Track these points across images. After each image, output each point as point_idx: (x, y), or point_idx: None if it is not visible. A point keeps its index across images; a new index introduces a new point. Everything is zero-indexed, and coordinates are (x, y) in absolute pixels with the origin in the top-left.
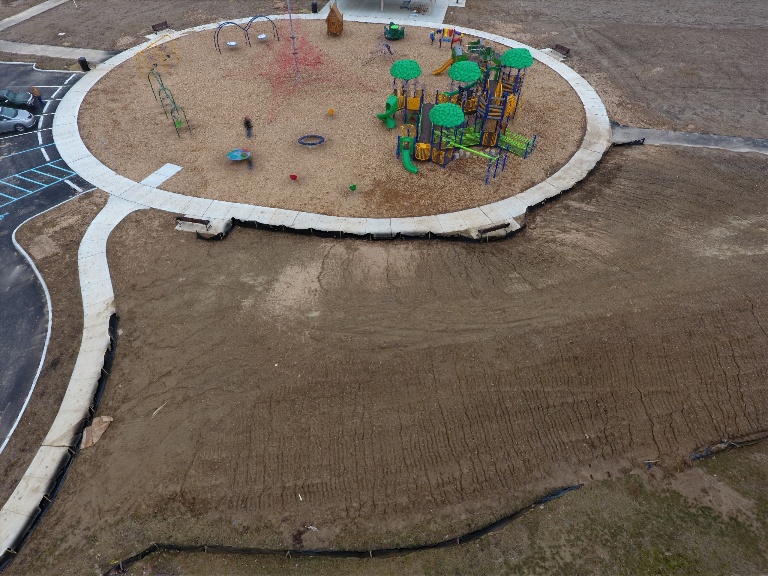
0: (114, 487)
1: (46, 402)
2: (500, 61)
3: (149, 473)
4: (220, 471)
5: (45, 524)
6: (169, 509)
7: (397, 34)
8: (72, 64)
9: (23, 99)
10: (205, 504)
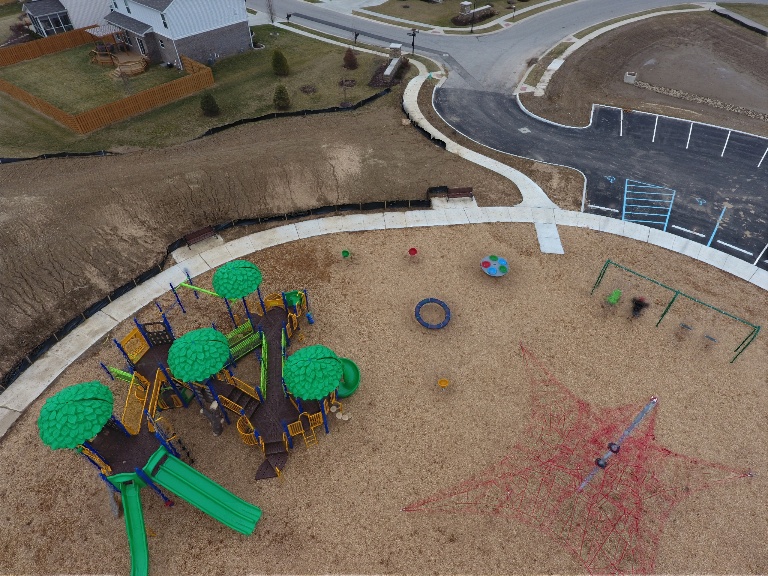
0: None
1: (440, 125)
2: None
3: None
4: None
5: None
6: None
7: None
8: None
9: None
10: None
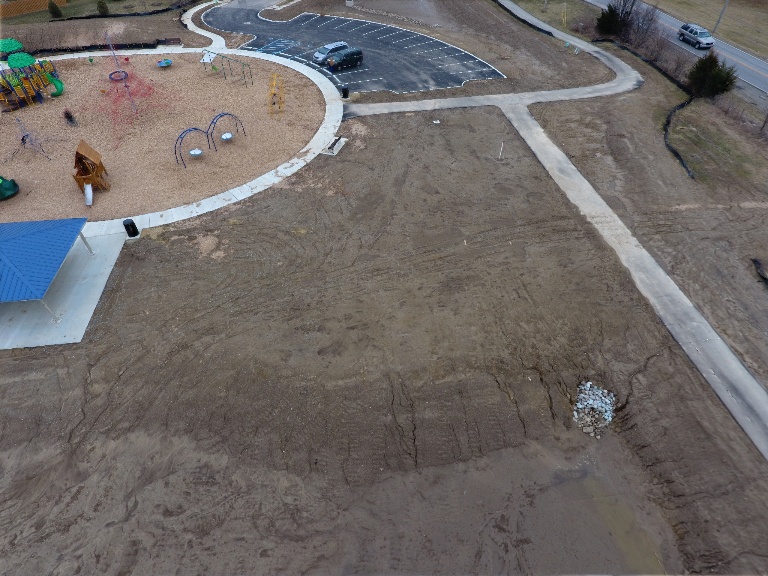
0: None
1: None
2: None
3: None
4: None
5: None
6: None
7: None
8: None
9: None
10: None
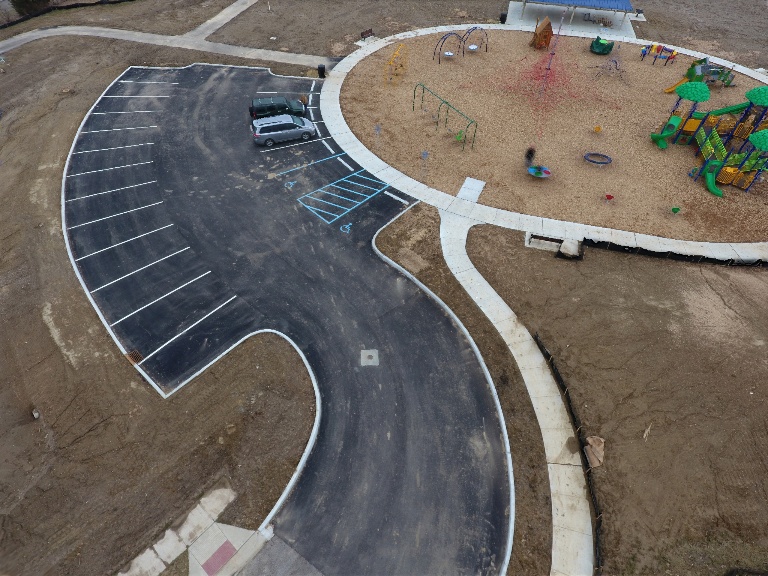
0: (652, 509)
1: (522, 419)
2: (730, 81)
3: (679, 496)
4: (751, 498)
5: (606, 542)
6: (717, 533)
7: (607, 49)
8: (306, 70)
9: (299, 107)
10: (753, 530)
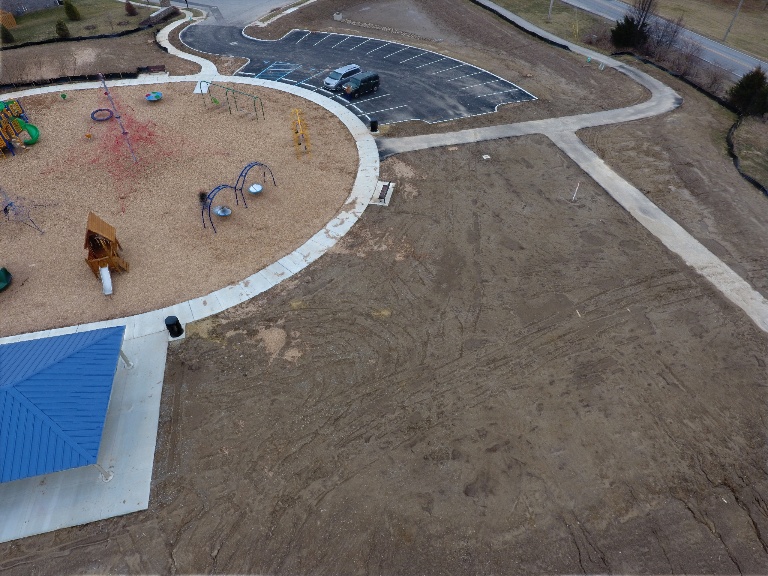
0: None
1: None
2: None
3: None
4: None
5: None
6: None
7: None
8: None
9: (346, 84)
10: None
